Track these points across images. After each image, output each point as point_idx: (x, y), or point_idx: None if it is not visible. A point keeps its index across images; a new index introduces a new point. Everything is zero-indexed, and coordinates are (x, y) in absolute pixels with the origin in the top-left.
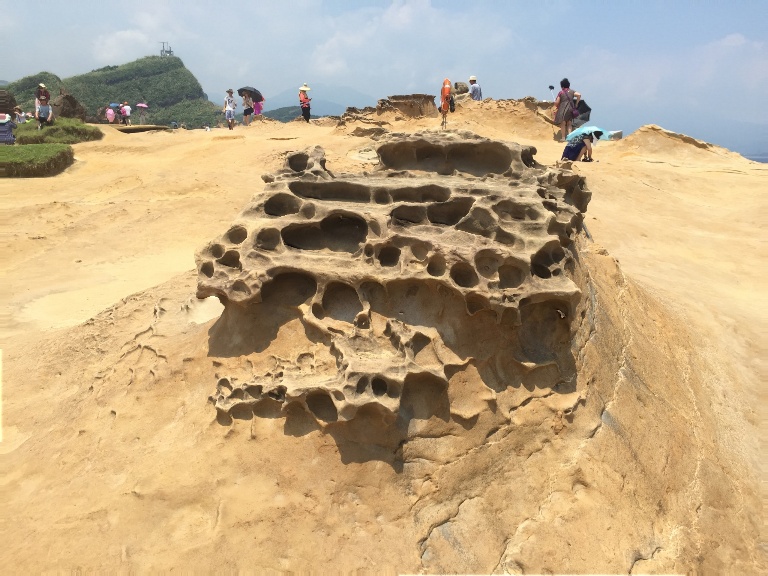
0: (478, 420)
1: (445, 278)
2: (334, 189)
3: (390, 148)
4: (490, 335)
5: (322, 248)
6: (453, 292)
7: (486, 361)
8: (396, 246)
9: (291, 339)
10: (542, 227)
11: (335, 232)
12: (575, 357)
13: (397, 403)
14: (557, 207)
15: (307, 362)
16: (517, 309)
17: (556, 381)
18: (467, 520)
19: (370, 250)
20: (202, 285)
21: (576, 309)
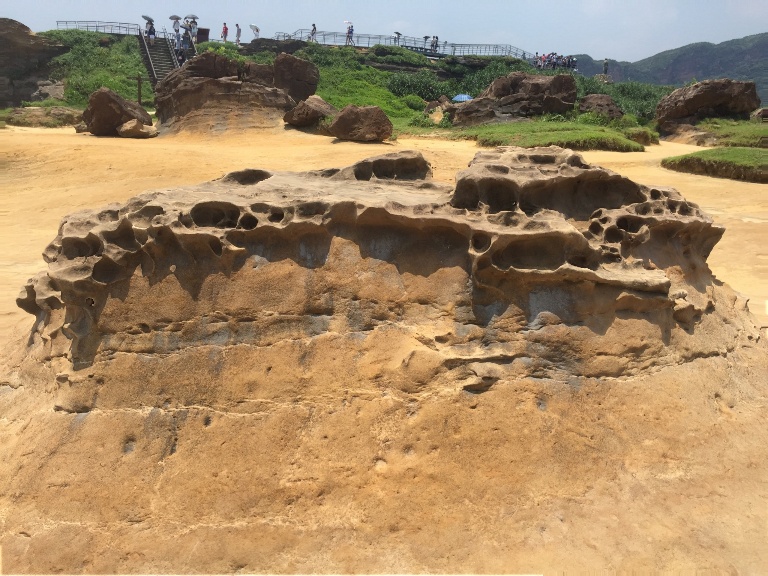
0: None
1: None
2: None
3: None
4: None
5: None
6: None
7: (67, 309)
8: None
9: None
10: None
11: None
12: (99, 350)
13: (20, 297)
14: None
15: None
16: None
17: None
18: None
19: None
20: None
21: (130, 315)
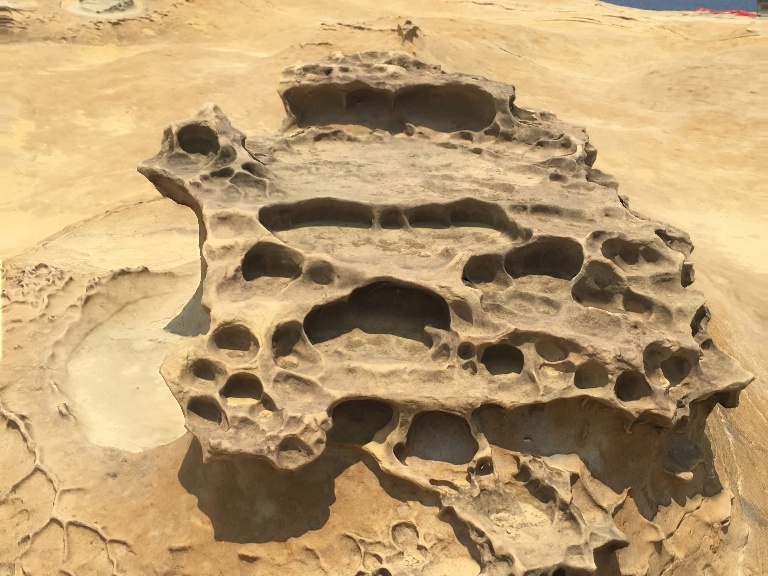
0: (648, 572)
1: (609, 396)
2: (309, 209)
3: (303, 91)
4: (641, 448)
5: (350, 330)
6: (613, 410)
7: None
8: (512, 344)
9: (360, 499)
10: (674, 278)
11: (366, 302)
12: (710, 439)
13: None
14: (667, 236)
15: (402, 536)
16: (688, 417)
17: (703, 482)
18: None
19: (465, 349)
20: (223, 450)
21: None
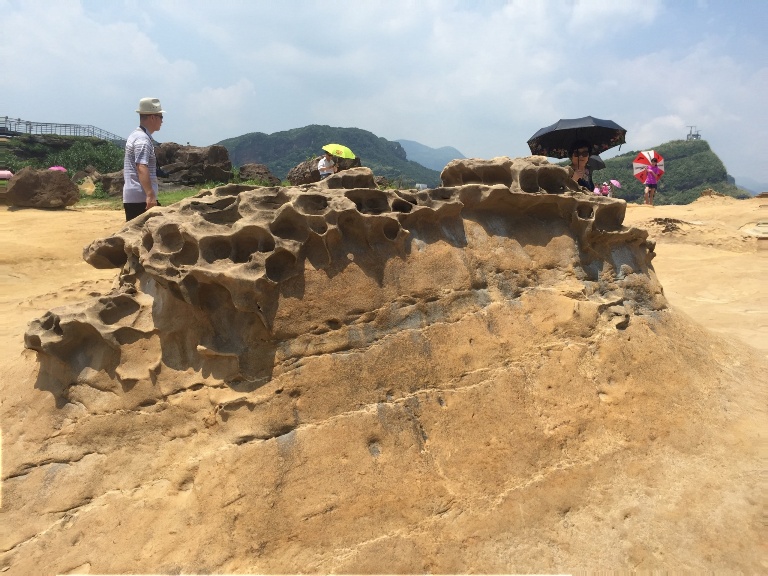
0: (135, 386)
1: None
2: None
3: (448, 174)
4: (184, 312)
5: None
6: None
7: (168, 335)
8: None
9: None
10: (274, 216)
11: None
12: (277, 360)
13: None
14: None
15: None
16: (179, 284)
17: (235, 376)
18: (79, 468)
19: None
20: None
21: (312, 313)
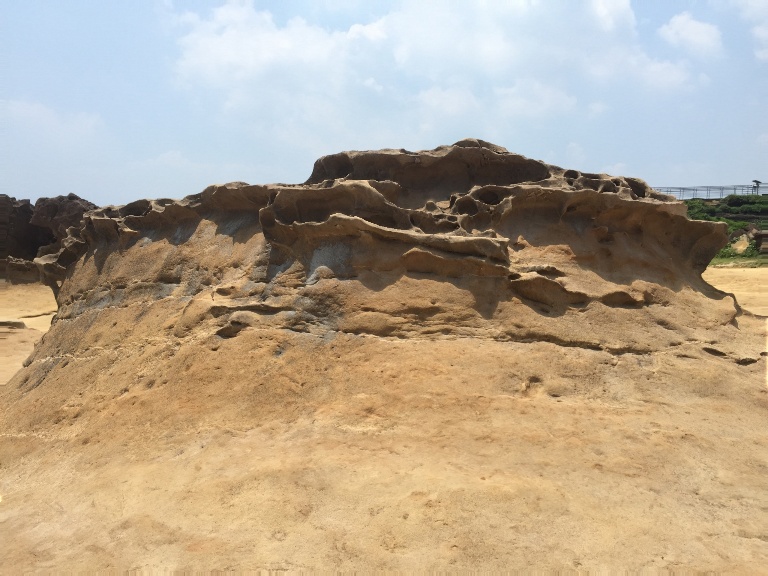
0: None
1: None
2: None
3: None
4: None
5: None
6: None
7: None
8: None
9: None
10: None
11: None
12: None
13: None
14: None
15: None
16: None
17: None
18: None
19: None
20: None
21: None
